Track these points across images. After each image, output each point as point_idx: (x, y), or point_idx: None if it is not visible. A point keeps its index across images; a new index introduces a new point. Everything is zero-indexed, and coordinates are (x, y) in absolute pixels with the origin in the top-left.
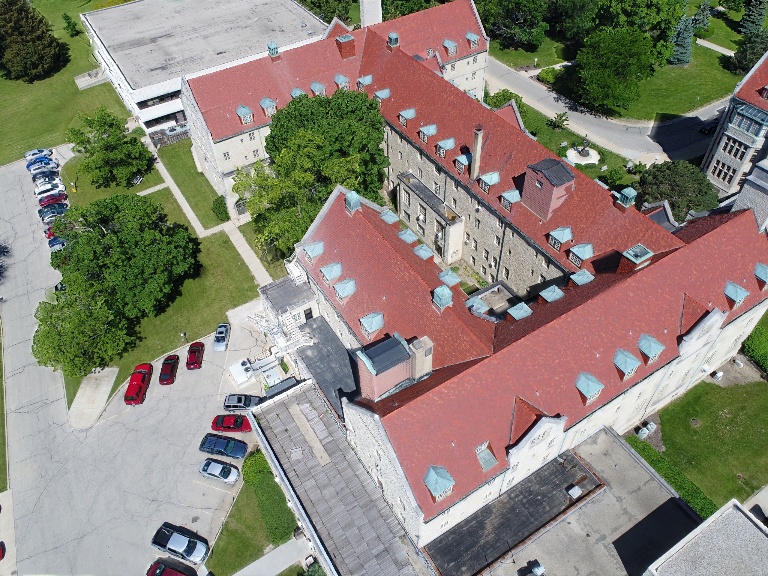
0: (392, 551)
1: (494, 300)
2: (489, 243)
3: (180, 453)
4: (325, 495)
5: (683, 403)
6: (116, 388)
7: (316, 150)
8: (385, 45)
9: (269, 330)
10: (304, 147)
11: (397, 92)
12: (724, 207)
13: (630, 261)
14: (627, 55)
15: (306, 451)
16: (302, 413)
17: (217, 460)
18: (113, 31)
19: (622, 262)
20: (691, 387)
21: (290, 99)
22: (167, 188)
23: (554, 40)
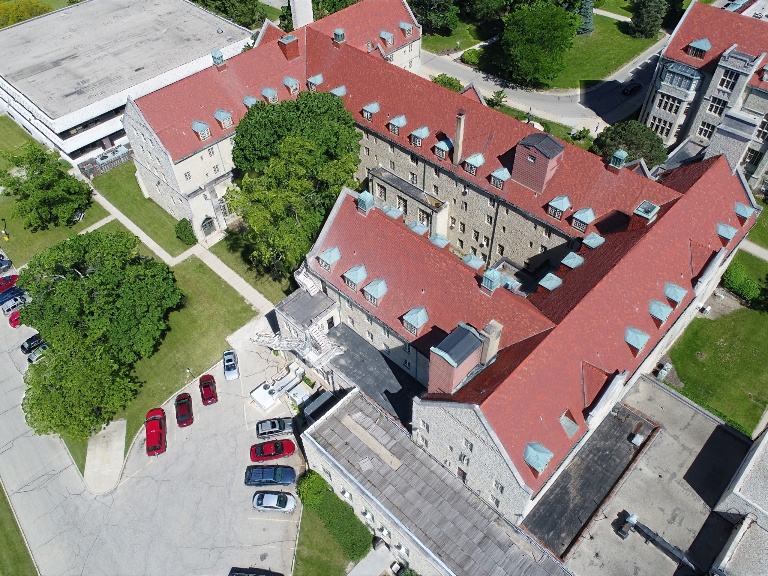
0: (492, 536)
1: None
2: (479, 224)
3: (225, 493)
4: (408, 498)
5: (685, 341)
6: (130, 441)
7: (306, 155)
8: (330, 42)
9: (297, 347)
10: (295, 154)
11: (354, 88)
12: (695, 157)
13: (642, 217)
14: (551, 29)
15: (374, 459)
16: (357, 423)
17: (267, 491)
18: (4, 58)
19: (633, 220)
20: (687, 325)
21: (244, 108)
22: (115, 220)
23: (465, 22)
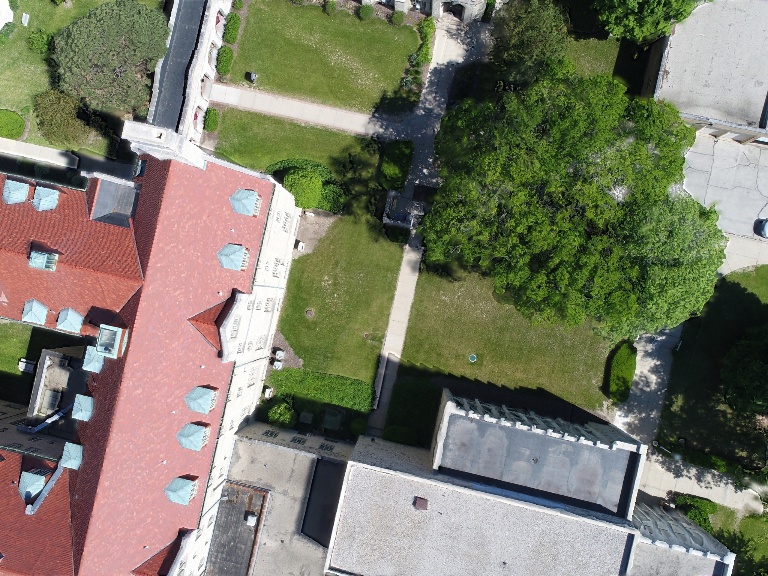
0: None
1: (57, 376)
2: None
3: None
4: None
5: (290, 301)
6: None
7: None
8: None
9: None
10: None
11: None
12: None
13: None
14: None
15: None
16: None
17: None
18: None
19: None
20: (287, 277)
21: None
22: None
23: None
